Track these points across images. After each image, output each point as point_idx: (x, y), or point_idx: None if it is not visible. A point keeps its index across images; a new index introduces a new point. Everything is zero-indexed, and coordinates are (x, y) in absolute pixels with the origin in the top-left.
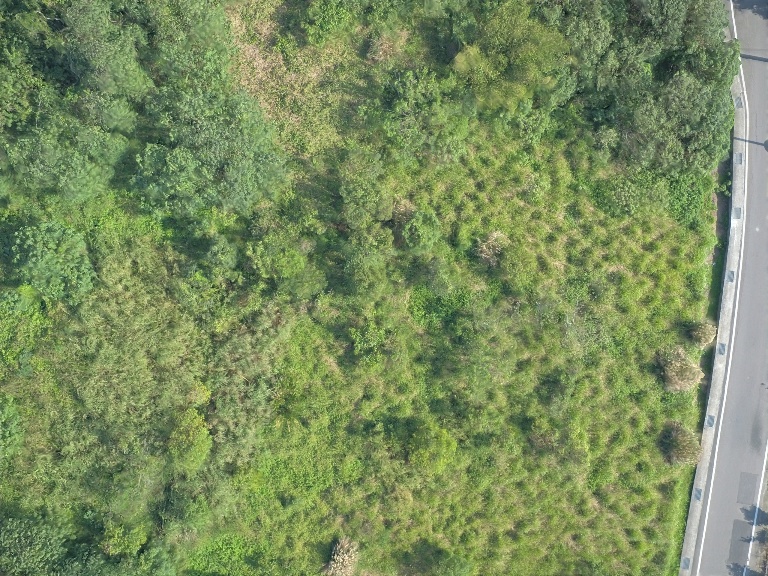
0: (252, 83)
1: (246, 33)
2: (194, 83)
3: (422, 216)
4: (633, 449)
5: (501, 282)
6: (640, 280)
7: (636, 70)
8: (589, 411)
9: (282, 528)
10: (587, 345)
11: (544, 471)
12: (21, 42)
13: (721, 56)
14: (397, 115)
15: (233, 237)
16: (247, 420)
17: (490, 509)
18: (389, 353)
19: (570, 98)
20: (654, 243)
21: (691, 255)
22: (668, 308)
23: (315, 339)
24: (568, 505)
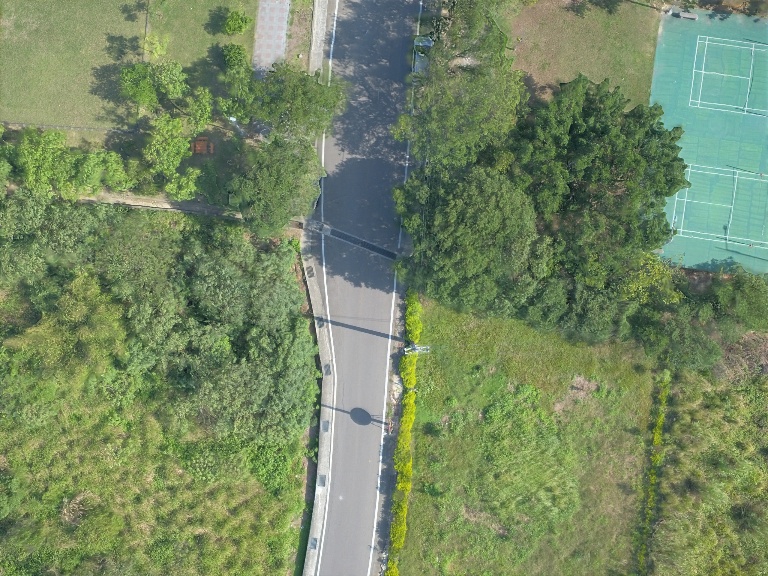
0: None
1: None
2: None
3: (0, 482)
4: None
5: None
6: (221, 546)
7: (204, 349)
8: None
9: None
10: None
11: None
12: None
13: (281, 341)
14: None
15: None
16: None
17: None
18: None
19: (155, 365)
20: (236, 509)
21: (274, 522)
22: (248, 574)
23: None
24: None
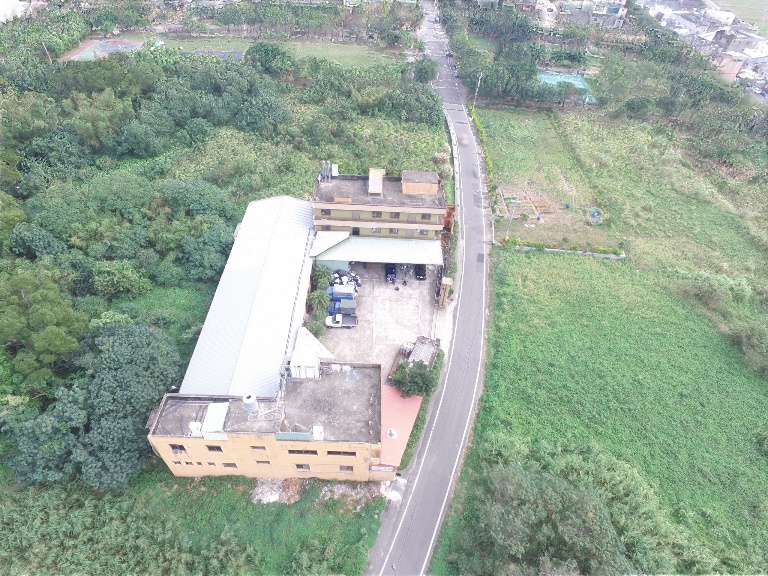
0: None
1: None
2: None
3: None
4: None
5: None
6: None
7: None
8: None
9: None
10: None
11: None
12: (205, 89)
13: None
14: None
15: None
16: None
17: None
18: None
19: None
20: None
21: None
22: None
23: None
24: None
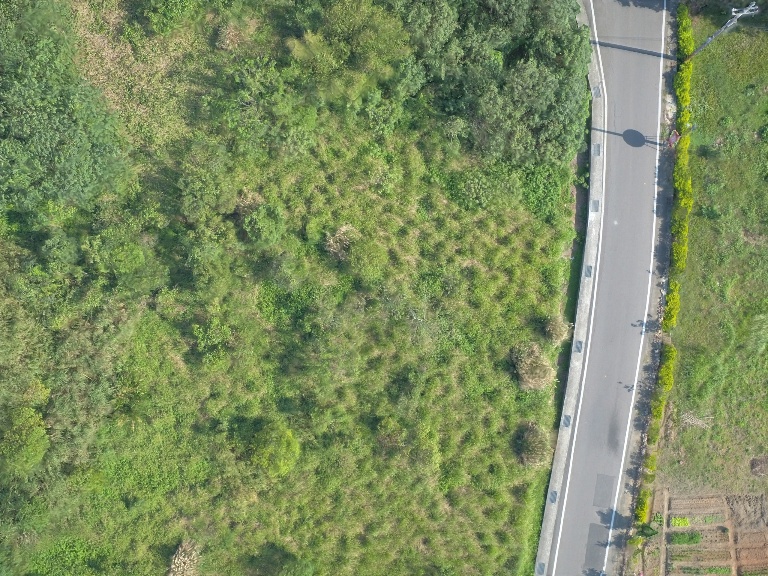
0: (100, 73)
1: (94, 22)
2: (28, 72)
3: (266, 209)
4: (486, 450)
5: (352, 277)
6: (493, 275)
7: (483, 58)
8: (440, 410)
9: (126, 531)
10: (440, 342)
11: (393, 472)
12: None
13: (568, 43)
14: (238, 105)
15: (79, 231)
16: (87, 419)
17: (338, 512)
18: (232, 350)
19: (421, 87)
20: (508, 237)
21: (547, 249)
22: (522, 304)
23: (161, 336)
24: (418, 508)
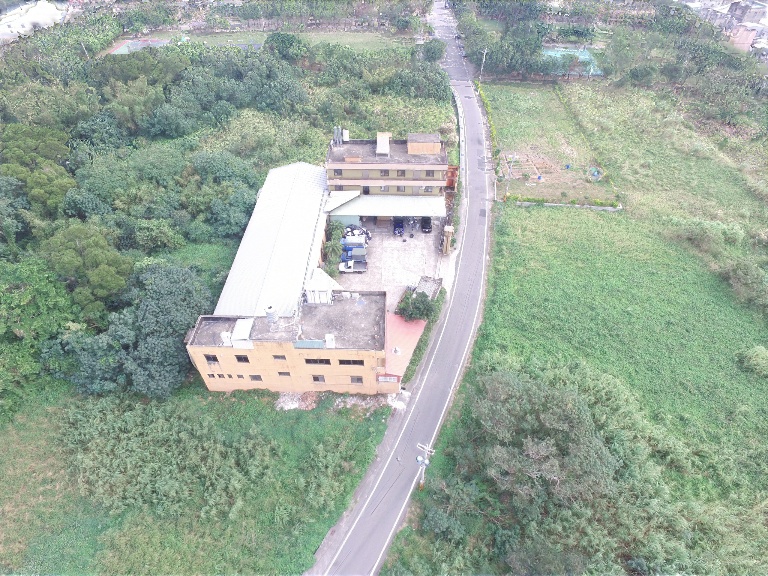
0: None
1: None
2: None
3: None
4: None
5: None
6: None
7: None
8: None
9: None
10: None
11: None
12: None
13: (442, 73)
14: None
15: None
16: None
17: None
18: None
19: None
20: None
21: None
22: None
23: None
24: None
